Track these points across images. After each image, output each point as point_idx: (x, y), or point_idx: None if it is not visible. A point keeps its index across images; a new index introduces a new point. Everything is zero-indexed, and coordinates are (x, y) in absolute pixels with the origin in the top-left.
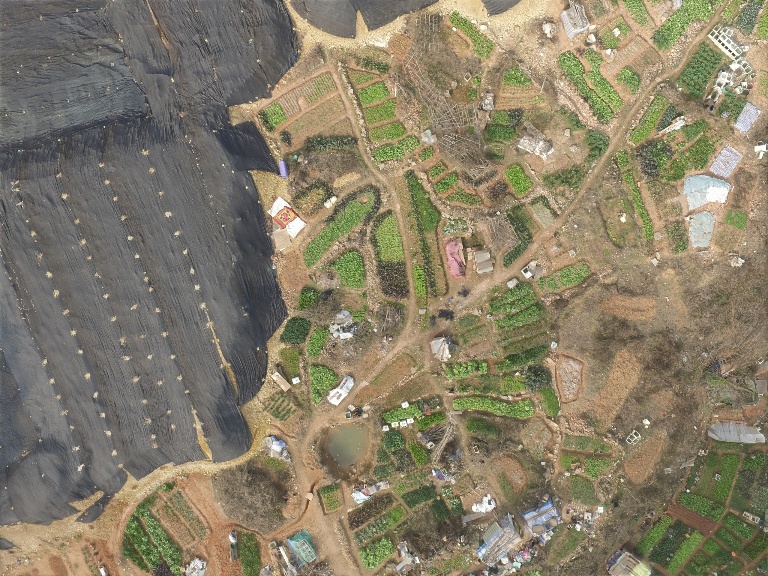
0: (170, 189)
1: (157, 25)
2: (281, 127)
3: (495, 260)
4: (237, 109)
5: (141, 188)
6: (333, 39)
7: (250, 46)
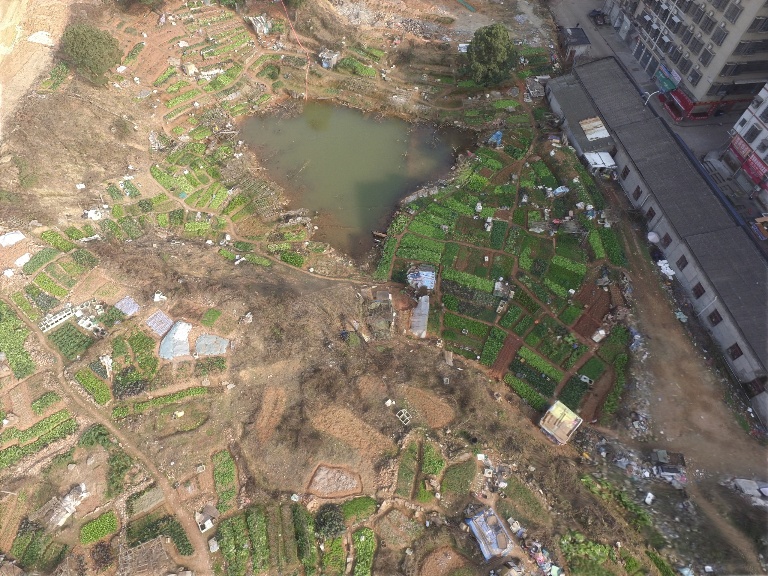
0: None
1: None
2: None
3: (181, 567)
4: None
5: None
6: None
7: None
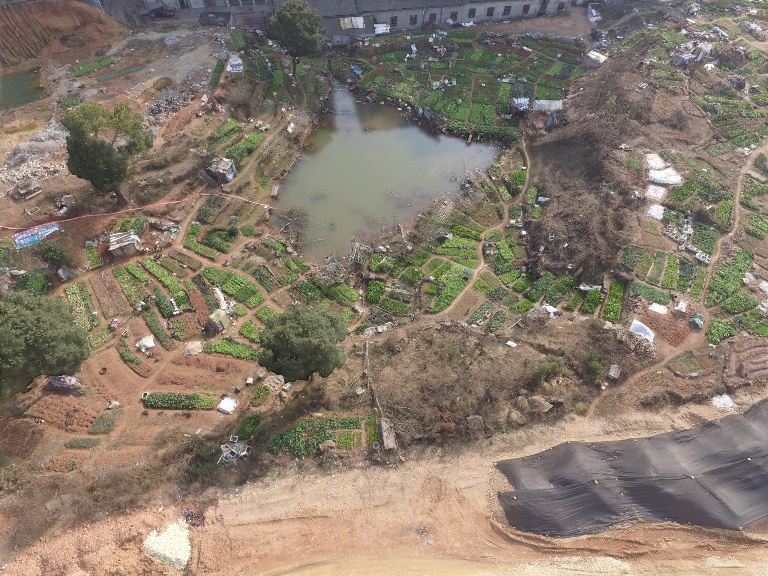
0: None
1: None
2: None
3: None
4: None
5: None
6: None
7: None
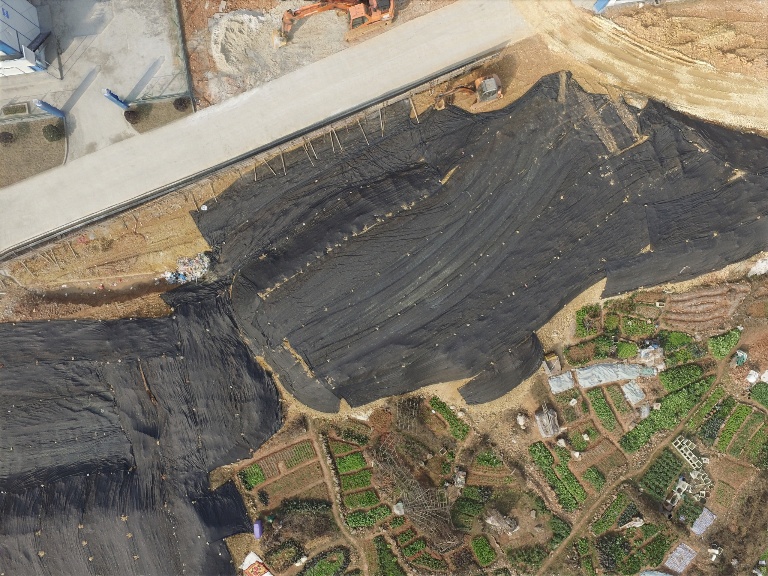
0: (145, 554)
1: (148, 390)
2: (260, 486)
3: None
4: (218, 471)
5: (117, 551)
6: (317, 412)
7: (236, 420)
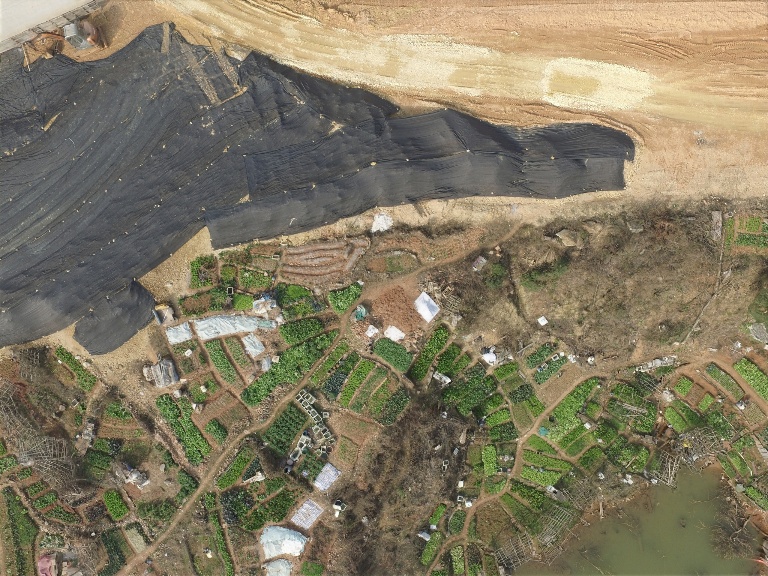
0: None
1: None
2: None
3: None
4: None
5: None
6: None
7: None
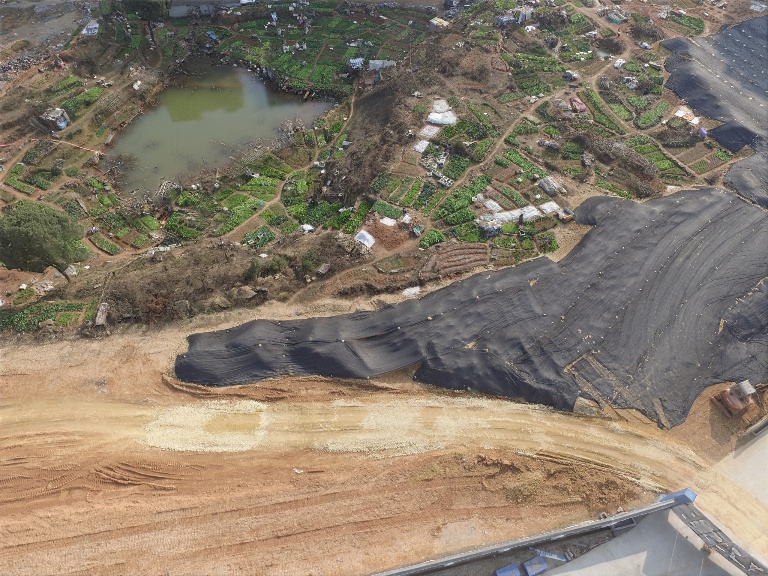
0: (767, 114)
1: None
2: None
3: None
4: (748, 155)
5: None
6: None
7: (760, 176)
